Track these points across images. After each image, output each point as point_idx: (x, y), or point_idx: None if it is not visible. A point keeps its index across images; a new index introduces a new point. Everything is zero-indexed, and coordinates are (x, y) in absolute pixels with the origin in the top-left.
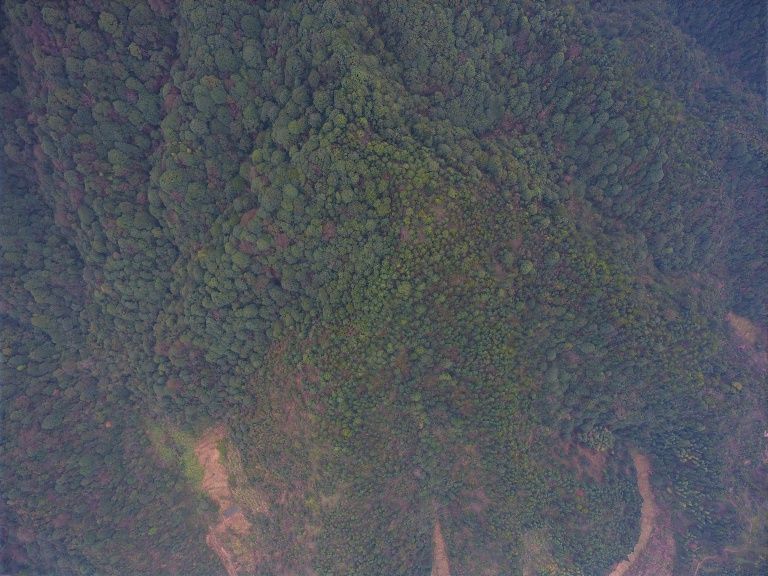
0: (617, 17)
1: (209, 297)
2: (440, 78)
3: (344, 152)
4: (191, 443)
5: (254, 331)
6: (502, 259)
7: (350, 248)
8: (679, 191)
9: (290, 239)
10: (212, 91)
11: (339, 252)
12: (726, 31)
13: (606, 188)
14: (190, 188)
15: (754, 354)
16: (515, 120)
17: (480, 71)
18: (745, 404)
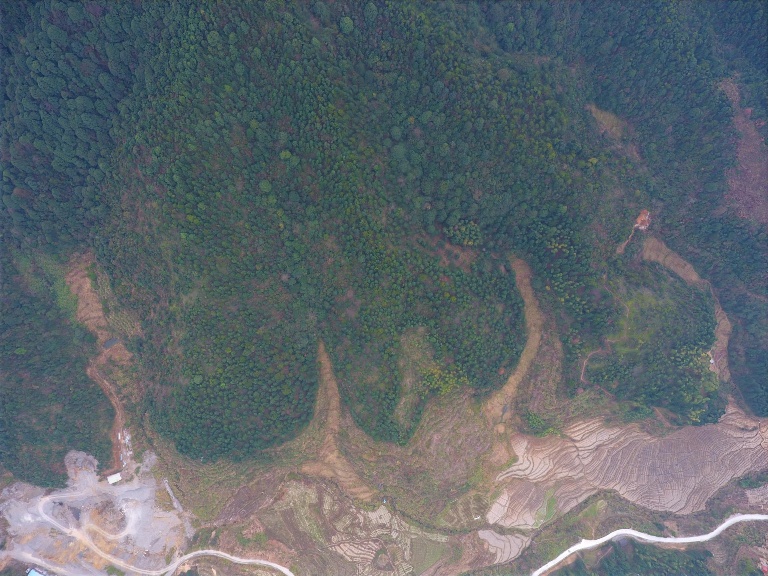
0: None
1: (37, 86)
2: None
3: None
4: (59, 271)
5: (96, 131)
6: (314, 9)
7: (161, 10)
8: None
9: (102, 8)
10: None
11: (153, 17)
12: None
13: None
14: None
15: (621, 146)
16: None
17: None
18: (602, 179)
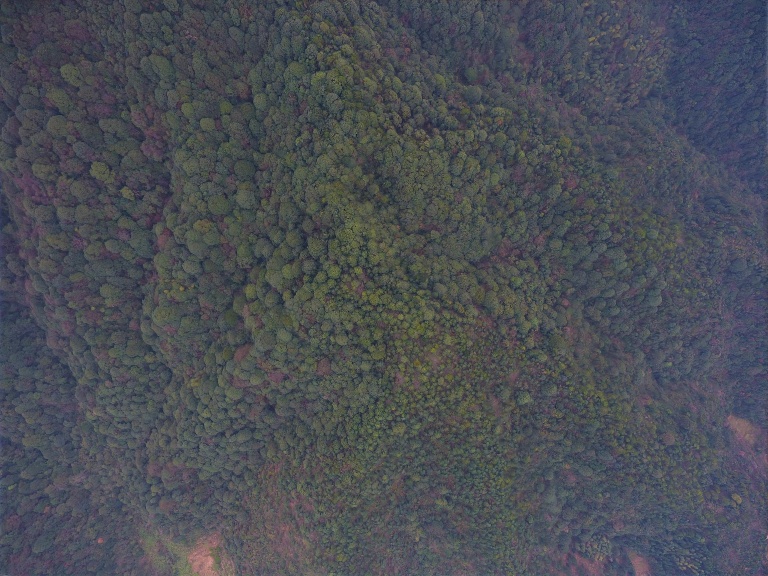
0: (615, 131)
1: (202, 425)
2: (436, 218)
3: (338, 303)
4: (184, 552)
5: (248, 451)
6: (499, 396)
7: (345, 384)
8: (678, 314)
9: (284, 374)
10: (205, 235)
11: (334, 387)
12: (725, 133)
13: (604, 309)
14: (183, 323)
15: (754, 457)
16: (512, 246)
17: (476, 206)
18: (745, 517)
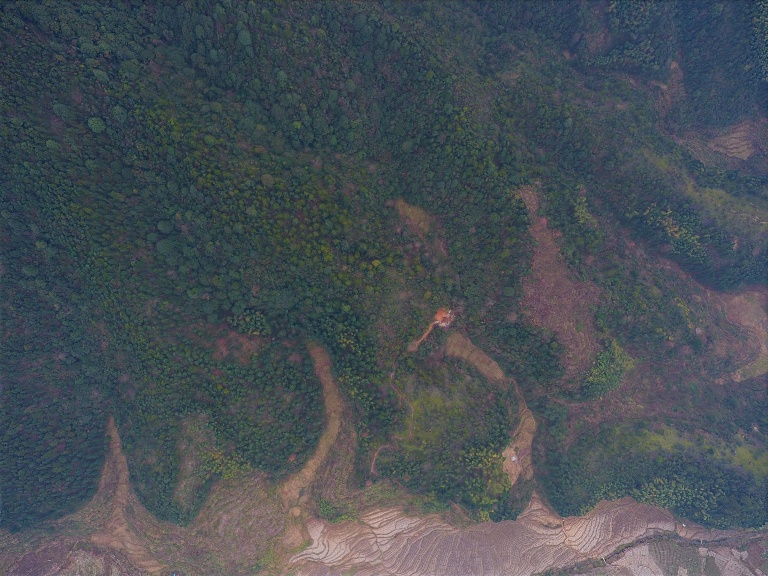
0: None
1: None
2: None
3: None
4: None
5: None
6: None
7: None
8: (276, 55)
9: None
10: None
11: None
12: None
13: (206, 54)
14: None
15: (425, 242)
16: None
17: None
18: (384, 282)
